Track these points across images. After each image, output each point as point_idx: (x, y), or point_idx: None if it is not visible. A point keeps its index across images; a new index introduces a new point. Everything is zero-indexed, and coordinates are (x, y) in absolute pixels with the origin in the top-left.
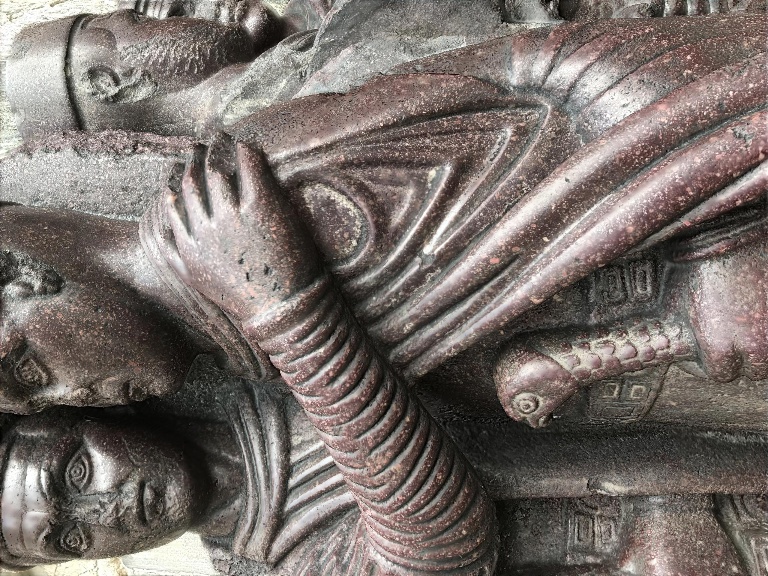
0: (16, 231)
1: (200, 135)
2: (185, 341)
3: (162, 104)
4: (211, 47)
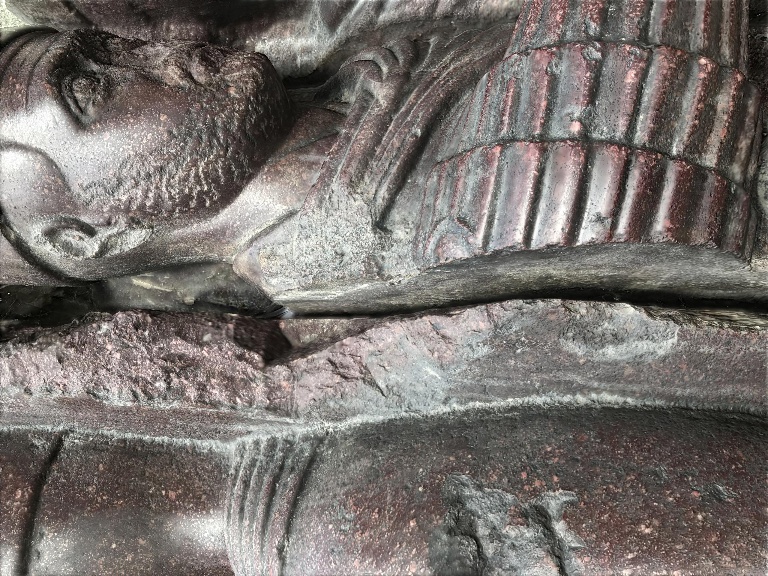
0: (85, 567)
1: (231, 262)
2: None
3: (167, 243)
4: (222, 164)
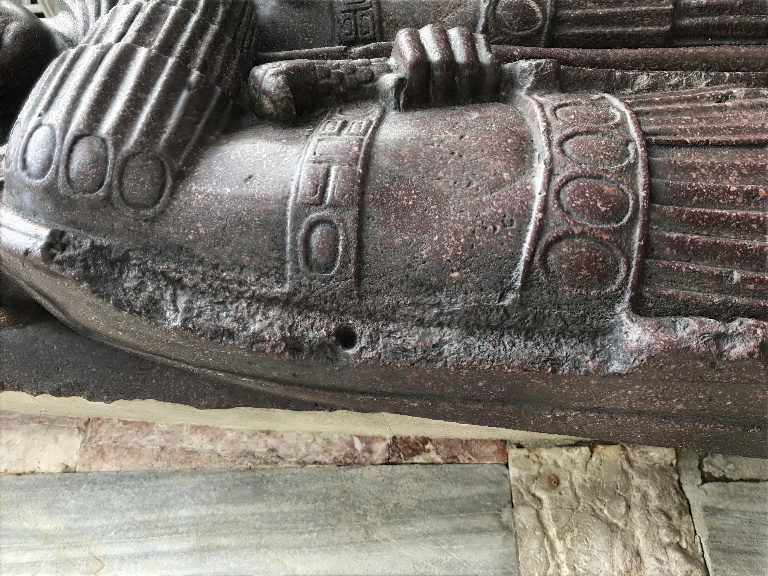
0: None
1: None
2: (49, 38)
3: None
4: None
